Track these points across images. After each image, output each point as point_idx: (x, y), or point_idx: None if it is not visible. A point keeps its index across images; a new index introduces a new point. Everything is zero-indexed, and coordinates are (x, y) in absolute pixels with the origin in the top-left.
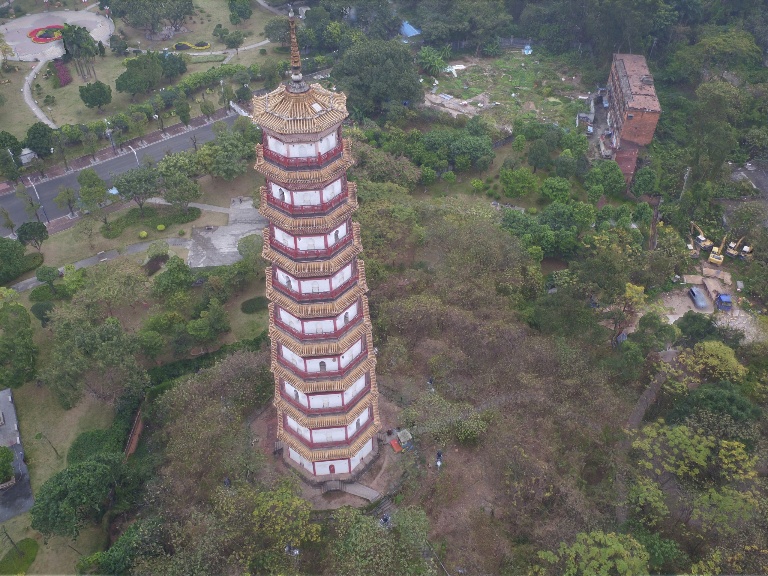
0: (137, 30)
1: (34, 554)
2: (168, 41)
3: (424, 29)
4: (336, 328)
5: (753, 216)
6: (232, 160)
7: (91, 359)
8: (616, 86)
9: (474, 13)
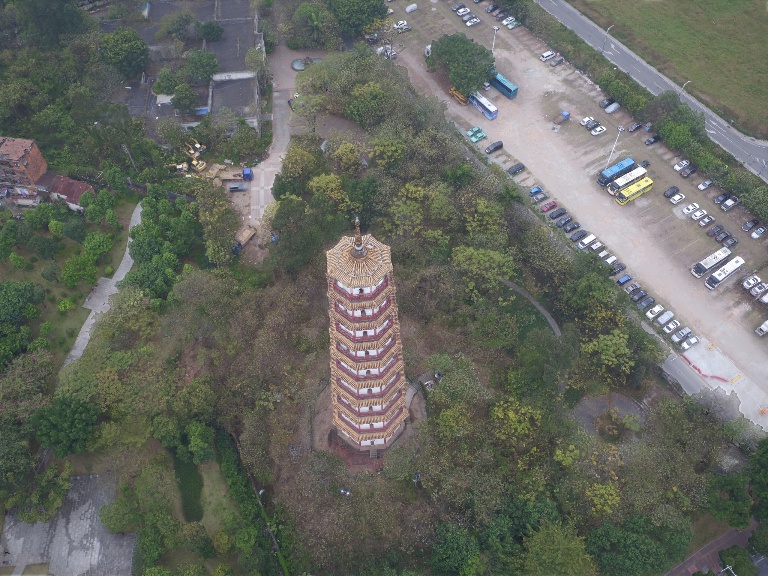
0: None
1: None
2: None
3: None
4: None
5: (172, 129)
6: None
7: None
8: None
9: None
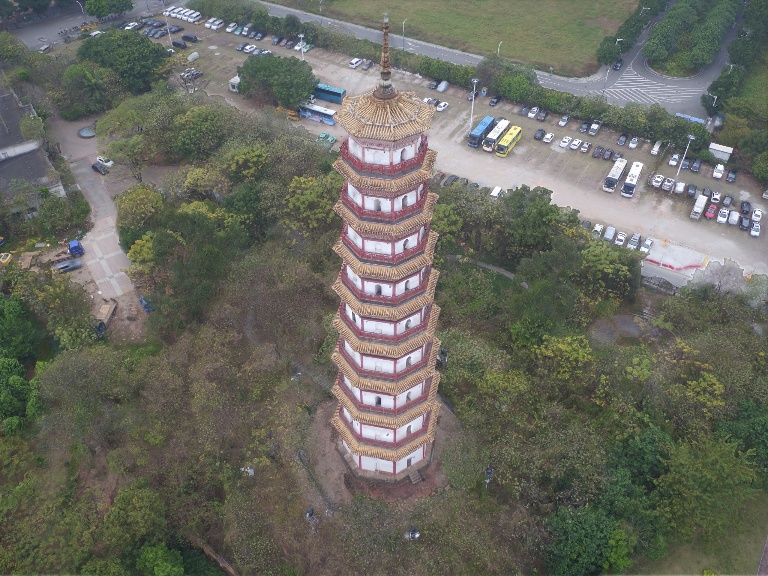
0: None
1: None
2: None
3: None
4: None
5: None
6: None
7: None
8: None
9: None
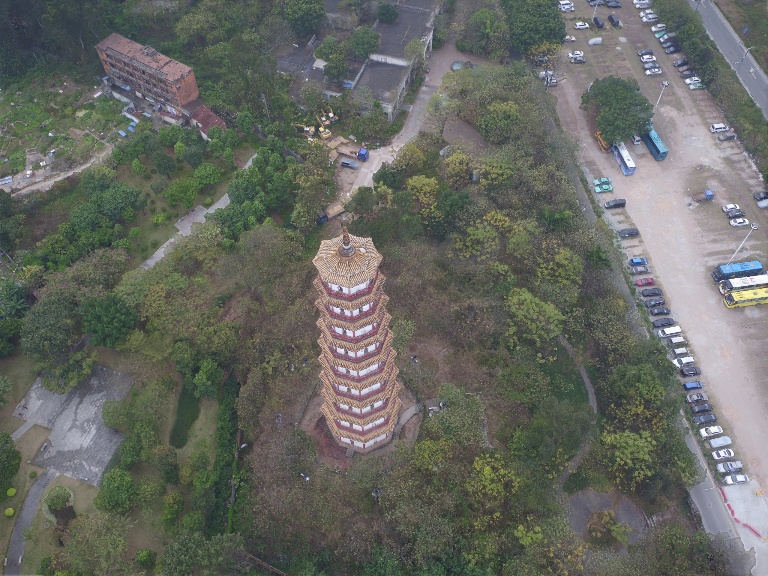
0: None
1: None
2: None
3: None
4: None
5: (314, 93)
6: None
7: (205, 569)
8: (129, 71)
9: None
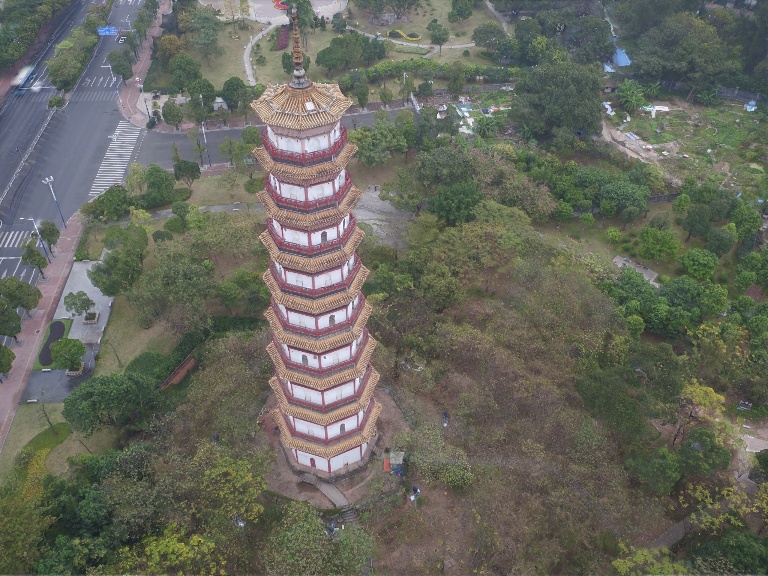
0: (364, 12)
1: (64, 438)
2: (386, 27)
3: (635, 61)
4: (318, 327)
5: None
6: (376, 148)
7: (167, 291)
8: None
9: (698, 54)
